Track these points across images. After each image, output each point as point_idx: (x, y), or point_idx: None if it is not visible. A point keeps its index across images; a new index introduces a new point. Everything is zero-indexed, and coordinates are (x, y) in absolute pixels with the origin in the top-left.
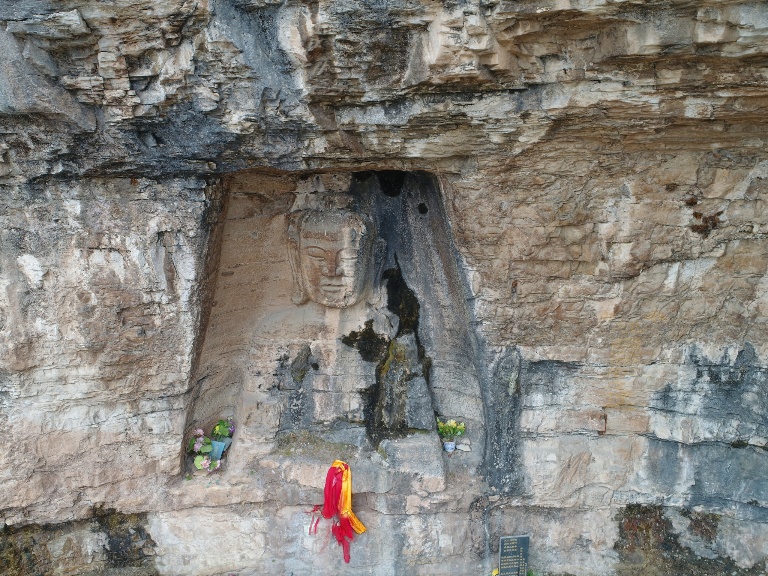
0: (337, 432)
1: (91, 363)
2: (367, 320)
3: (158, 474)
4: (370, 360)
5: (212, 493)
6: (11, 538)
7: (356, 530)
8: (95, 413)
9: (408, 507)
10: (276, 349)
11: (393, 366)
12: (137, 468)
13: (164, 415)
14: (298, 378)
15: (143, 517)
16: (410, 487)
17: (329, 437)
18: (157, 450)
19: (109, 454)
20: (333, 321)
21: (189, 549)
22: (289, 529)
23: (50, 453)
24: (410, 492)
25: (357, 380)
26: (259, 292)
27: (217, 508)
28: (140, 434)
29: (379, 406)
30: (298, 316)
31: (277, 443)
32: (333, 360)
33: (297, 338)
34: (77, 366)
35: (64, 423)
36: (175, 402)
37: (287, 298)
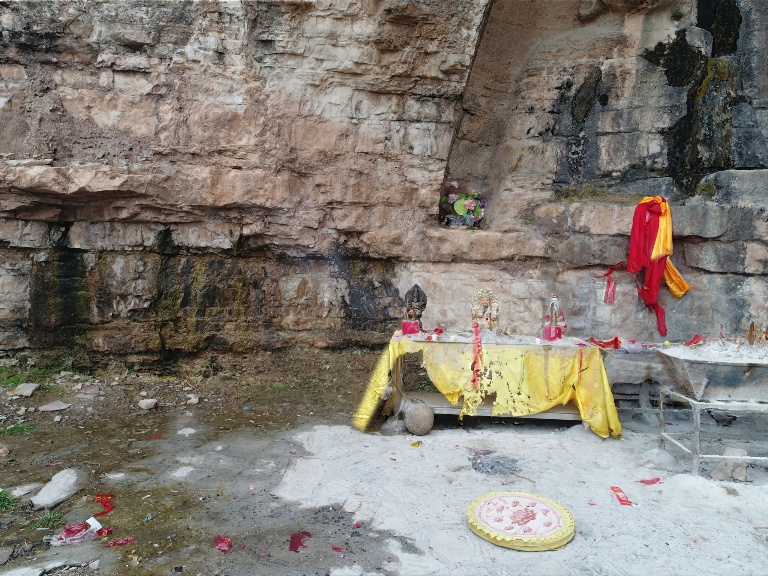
0: (631, 183)
1: (371, 14)
2: (678, 30)
3: (415, 208)
4: (679, 84)
5: (479, 240)
6: (241, 263)
7: (675, 290)
8: (357, 103)
9: (748, 261)
10: (557, 73)
11: (713, 87)
12: (394, 190)
13: (429, 128)
14: (581, 114)
15: (390, 268)
16: (752, 229)
17: (620, 190)
18: (416, 176)
19: (365, 165)
20: (634, 31)
21: (446, 314)
22: (575, 297)
23: (303, 145)
24: (752, 238)
25: (658, 115)
26: (538, 5)
27: (481, 265)
28: (400, 150)
29: (692, 142)
30: (587, 30)
31: (554, 194)
32: (629, 87)
33: (585, 58)
34: (353, 20)
35: (323, 107)
36: (445, 110)
37: (568, 20)
